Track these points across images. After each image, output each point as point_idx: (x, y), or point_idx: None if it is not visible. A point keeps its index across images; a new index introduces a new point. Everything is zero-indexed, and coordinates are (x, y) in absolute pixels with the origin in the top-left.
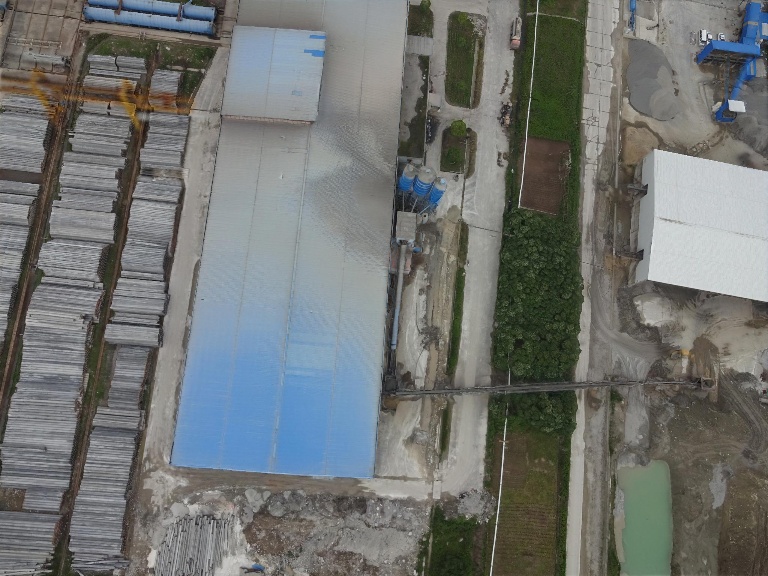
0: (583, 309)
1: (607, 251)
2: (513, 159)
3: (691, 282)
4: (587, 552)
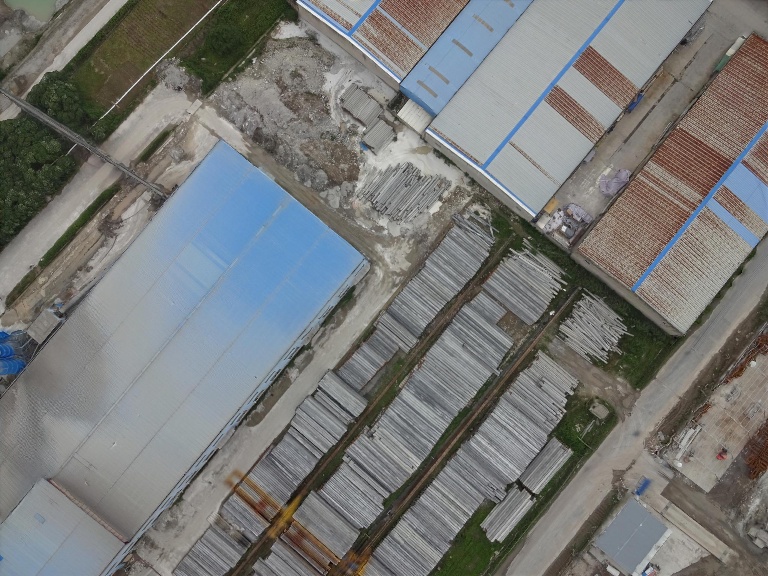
0: None
1: None
2: None
3: None
4: None
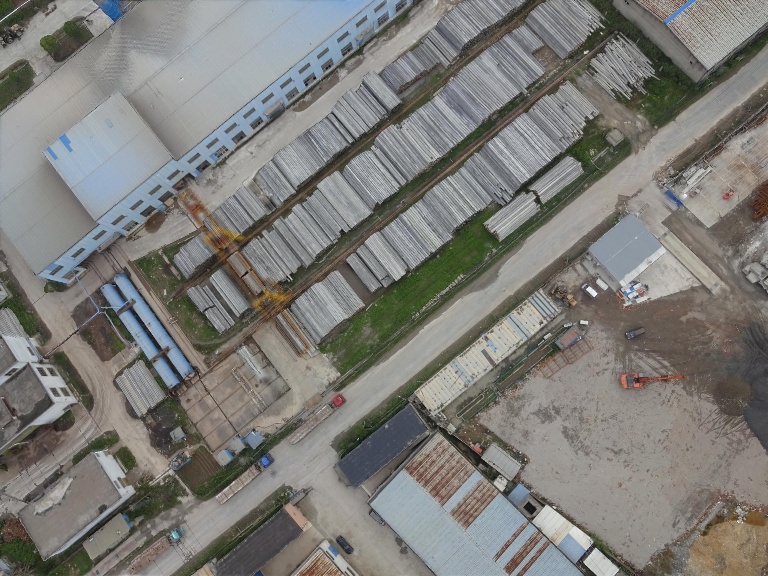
0: None
1: None
2: (43, 3)
3: None
4: None
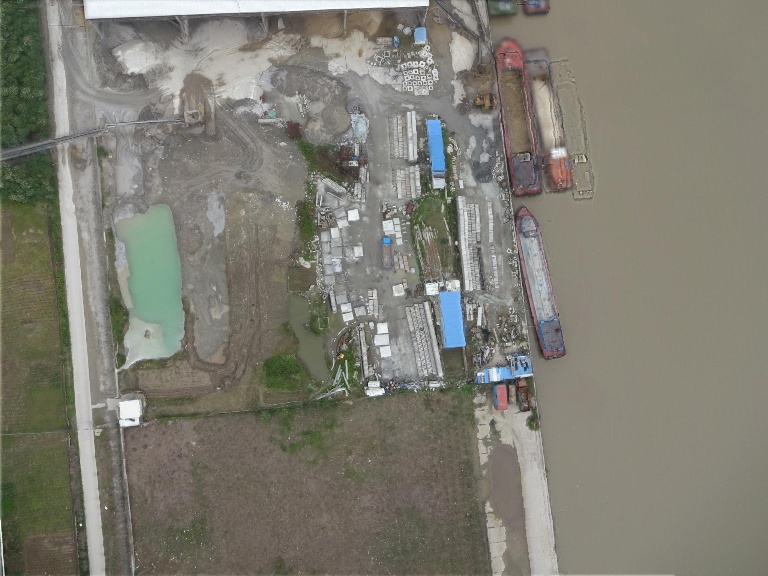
0: (56, 73)
1: (76, 8)
2: None
3: (135, 11)
4: (91, 307)
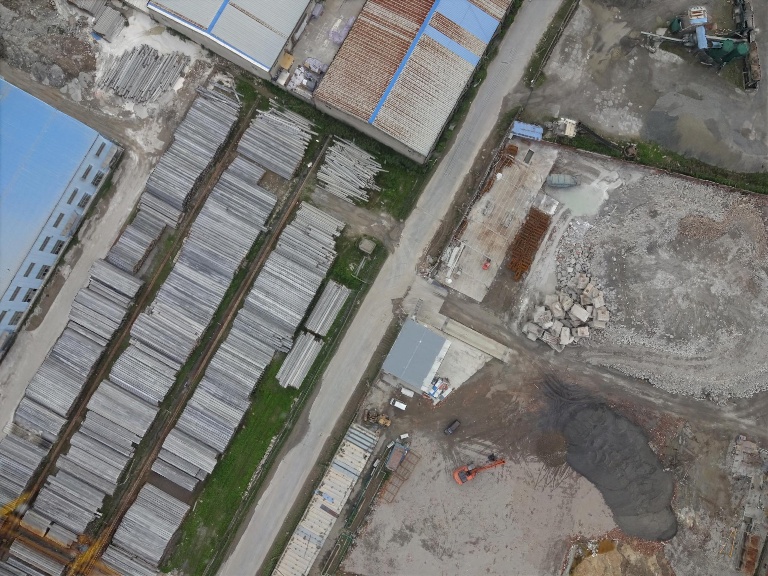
0: None
1: None
2: None
3: None
4: None
